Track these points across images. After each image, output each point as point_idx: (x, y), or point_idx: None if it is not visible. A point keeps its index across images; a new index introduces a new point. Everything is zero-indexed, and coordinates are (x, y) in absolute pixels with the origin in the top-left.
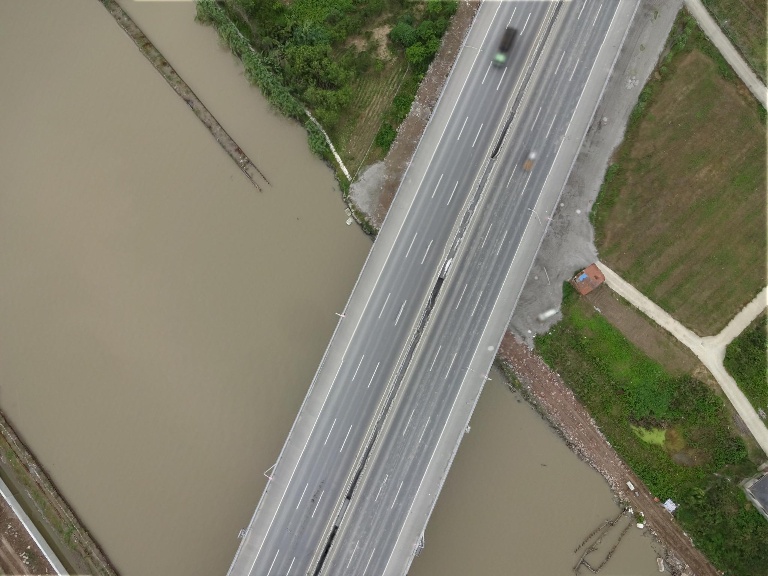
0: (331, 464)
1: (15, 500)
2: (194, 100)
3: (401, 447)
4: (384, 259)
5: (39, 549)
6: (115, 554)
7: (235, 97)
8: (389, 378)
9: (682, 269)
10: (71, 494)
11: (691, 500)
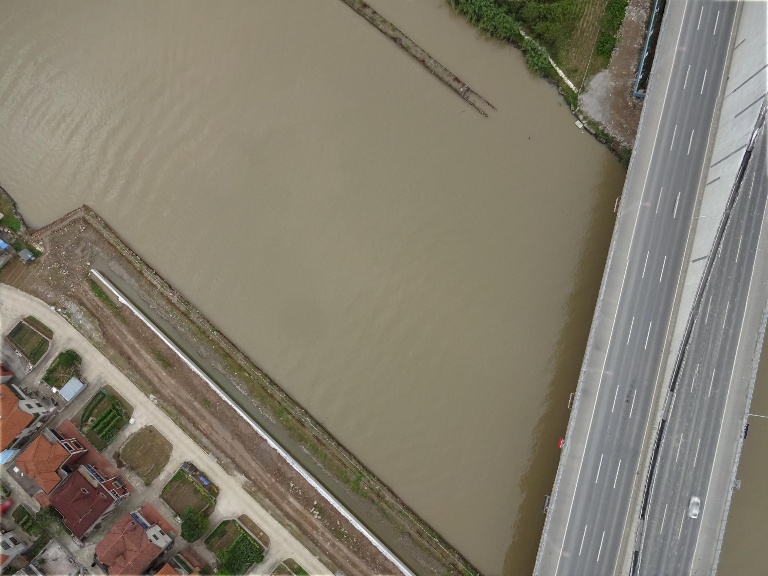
0: (638, 362)
1: (292, 458)
2: (402, 37)
3: (706, 335)
4: (649, 155)
5: (326, 503)
6: (408, 495)
7: (441, 29)
8: (679, 270)
9: None
10: (351, 442)
11: None
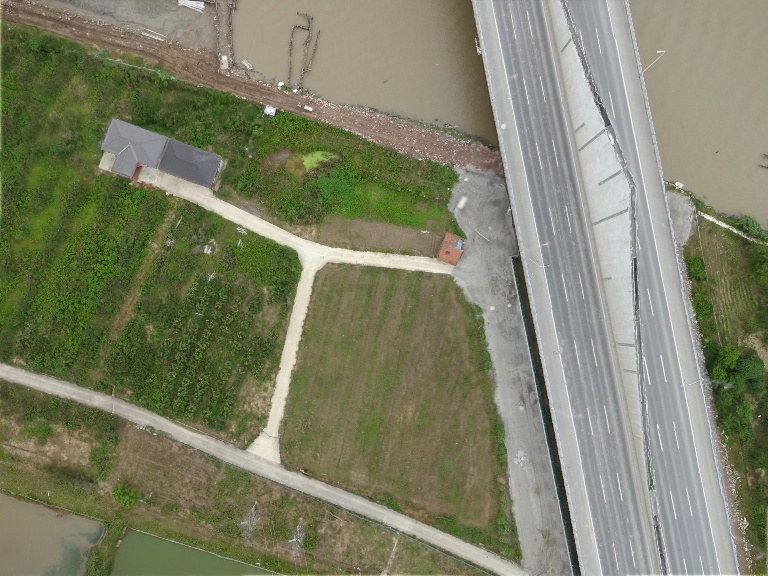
0: None
1: None
2: None
3: (523, 1)
4: (639, 143)
5: None
6: None
7: None
8: None
9: (377, 313)
10: None
11: (260, 121)
